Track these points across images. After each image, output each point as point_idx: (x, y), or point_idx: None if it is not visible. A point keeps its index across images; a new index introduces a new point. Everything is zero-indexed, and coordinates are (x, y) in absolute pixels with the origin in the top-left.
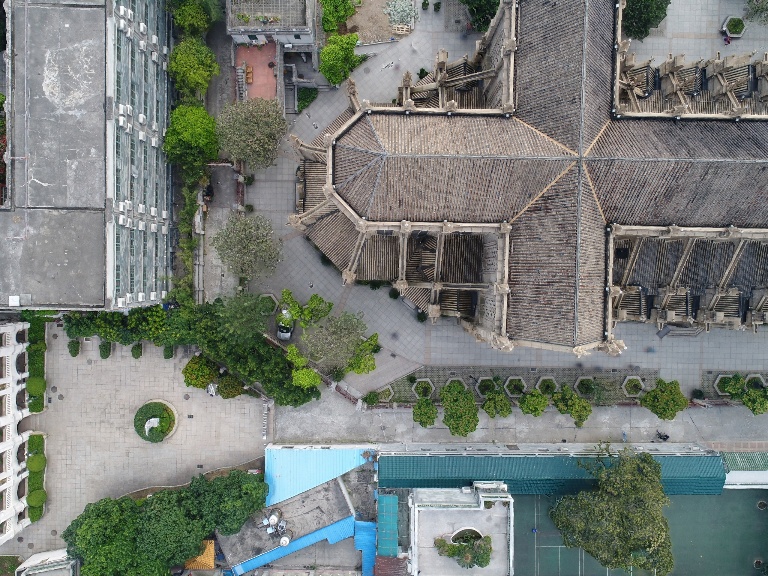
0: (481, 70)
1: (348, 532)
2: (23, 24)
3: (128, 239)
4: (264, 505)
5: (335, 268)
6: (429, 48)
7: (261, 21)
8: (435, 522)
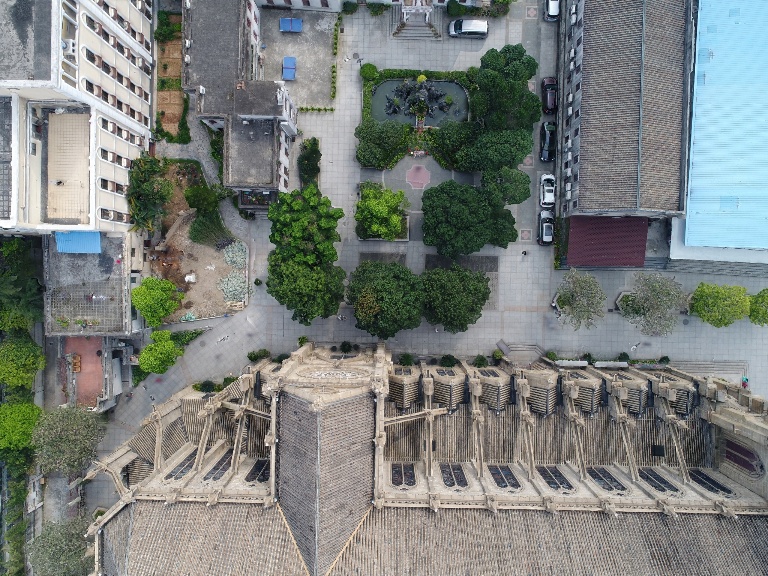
0: None
1: None
2: None
3: None
4: None
5: None
6: (264, 322)
7: (80, 325)
8: None
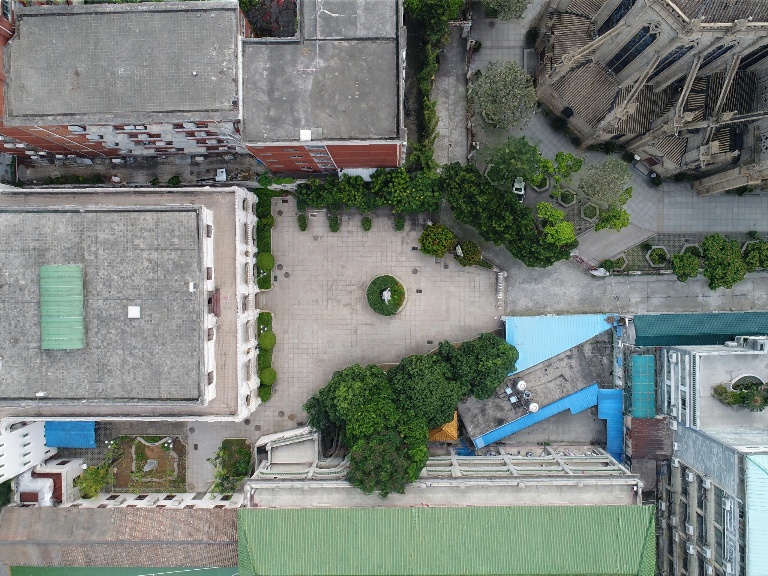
0: None
1: (591, 401)
2: None
3: None
4: (516, 368)
5: (565, 134)
6: None
7: None
8: (712, 370)
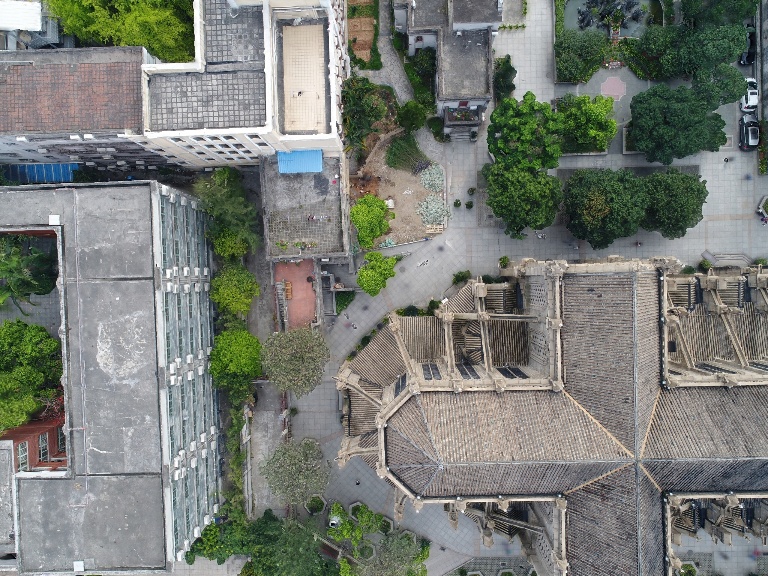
0: (520, 289)
1: None
2: (75, 299)
3: (183, 485)
4: None
5: None
6: (463, 244)
7: (299, 248)
8: None
